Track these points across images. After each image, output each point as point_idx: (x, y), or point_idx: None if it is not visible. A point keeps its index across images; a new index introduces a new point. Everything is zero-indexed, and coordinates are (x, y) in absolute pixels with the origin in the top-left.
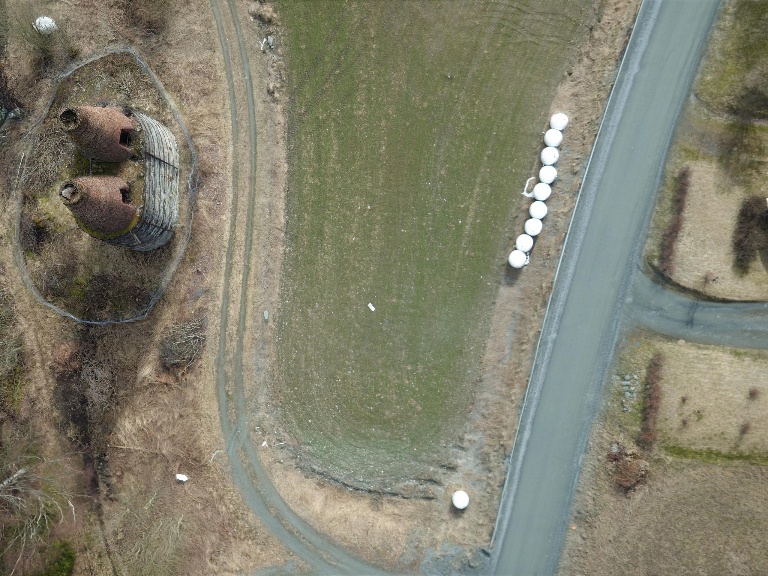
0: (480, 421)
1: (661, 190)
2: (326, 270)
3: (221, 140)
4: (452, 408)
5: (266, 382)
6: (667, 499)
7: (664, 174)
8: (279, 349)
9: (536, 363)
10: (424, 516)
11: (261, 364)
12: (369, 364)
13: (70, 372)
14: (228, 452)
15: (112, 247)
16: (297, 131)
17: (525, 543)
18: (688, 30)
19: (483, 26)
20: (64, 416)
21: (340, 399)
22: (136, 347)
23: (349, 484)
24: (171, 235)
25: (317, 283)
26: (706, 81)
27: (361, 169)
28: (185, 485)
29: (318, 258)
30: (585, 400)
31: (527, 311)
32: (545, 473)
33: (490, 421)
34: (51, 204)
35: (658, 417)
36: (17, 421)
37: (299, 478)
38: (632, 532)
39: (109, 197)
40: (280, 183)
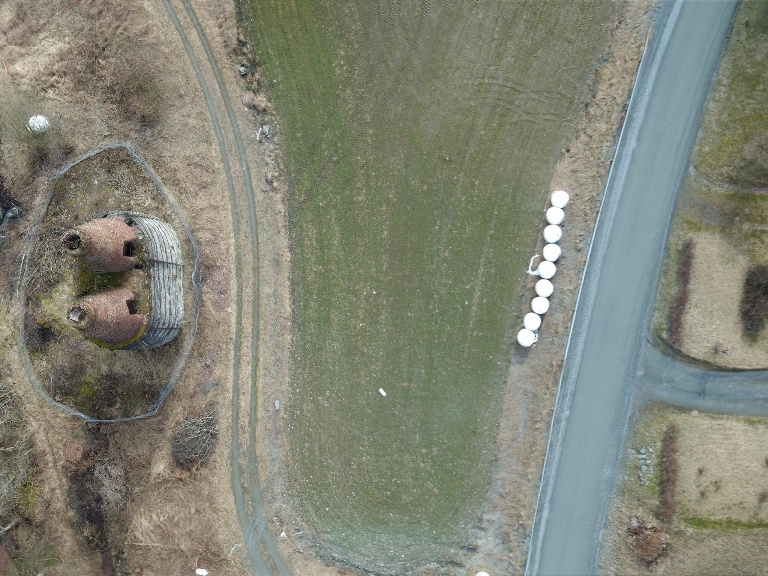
0: (498, 500)
1: (666, 263)
2: (335, 357)
3: (222, 232)
4: (469, 489)
5: (281, 472)
6: (689, 570)
7: (668, 247)
8: (292, 438)
9: (551, 442)
10: None
11: (275, 454)
12: (383, 449)
13: (83, 470)
14: (247, 545)
15: None
16: (298, 219)
17: None
18: (684, 103)
19: (478, 107)
20: (79, 515)
21: (356, 486)
22: (148, 443)
23: (370, 570)
24: (178, 331)
25: (327, 370)
26: (704, 152)
27: (364, 255)
28: None
29: (326, 345)
30: (602, 476)
31: (539, 389)
32: (566, 551)
33: (508, 500)
34: (55, 305)
35: (676, 490)
36: (33, 524)
37: (319, 567)
38: None
39: (116, 312)
40: (284, 272)
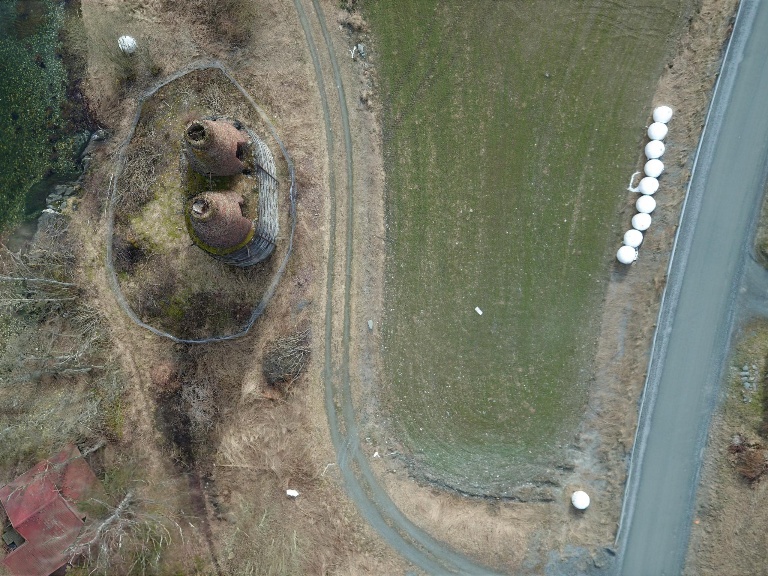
0: (595, 420)
1: None
2: (430, 276)
3: (316, 151)
4: (566, 408)
5: (374, 392)
6: None
7: None
8: (386, 358)
9: (653, 358)
10: (543, 519)
11: (368, 374)
12: (479, 368)
13: (170, 393)
14: (340, 465)
15: (210, 264)
16: (393, 138)
17: (650, 540)
18: None
19: (580, 23)
20: (167, 437)
21: (451, 405)
22: (237, 364)
23: (464, 490)
24: (272, 249)
25: (421, 290)
26: None
27: (461, 173)
28: (296, 500)
29: (421, 264)
30: (703, 393)
31: (639, 307)
32: (667, 468)
33: (606, 419)
34: (146, 224)
35: None
36: (120, 445)
37: (413, 487)
38: (758, 523)
39: (232, 210)
40: (378, 191)
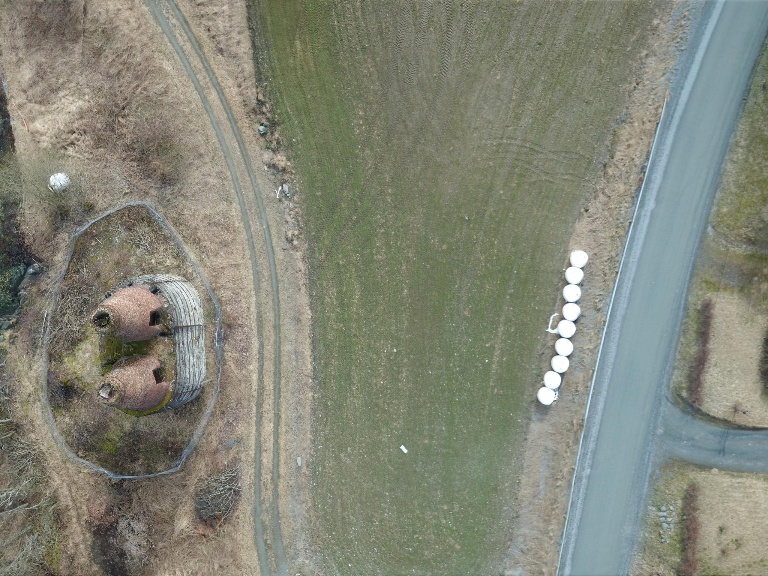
0: (519, 557)
1: (685, 322)
2: (356, 414)
3: (243, 291)
4: (490, 545)
5: (303, 528)
6: None
7: (687, 306)
8: (314, 495)
9: (572, 500)
10: None
11: (297, 510)
12: (405, 506)
13: (106, 526)
14: None
15: None
16: (318, 277)
17: None
18: (701, 164)
19: (497, 167)
20: (103, 570)
21: (378, 542)
22: (171, 498)
23: None
24: (200, 390)
25: (348, 428)
26: (722, 213)
27: (385, 313)
28: None
29: (347, 403)
30: (623, 533)
31: (559, 447)
32: None
33: (529, 556)
34: (78, 363)
35: (697, 547)
36: None
37: None
38: None
39: (144, 384)
40: (305, 330)
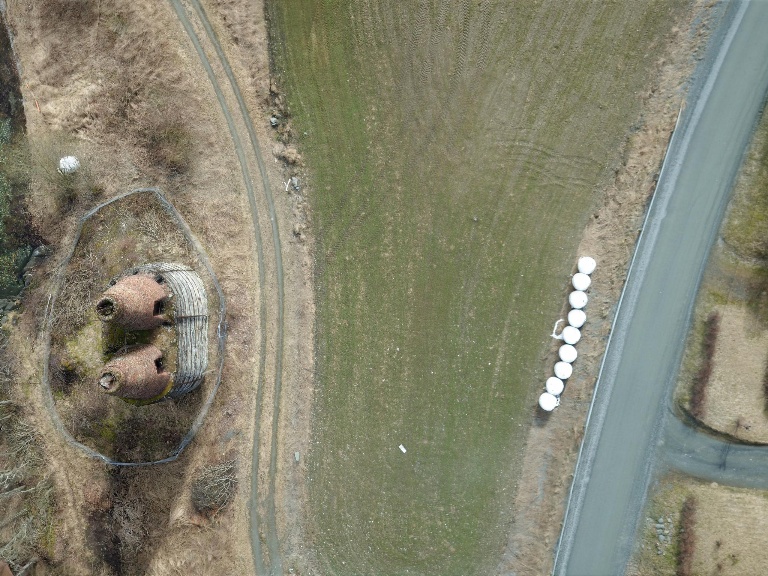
0: (514, 562)
1: (691, 333)
2: (356, 411)
3: (248, 282)
4: (486, 549)
5: (299, 523)
6: None
7: (693, 318)
8: (311, 490)
9: (570, 508)
10: None
11: (293, 505)
12: (401, 506)
13: (102, 511)
14: None
15: None
16: (324, 272)
17: None
18: (714, 175)
19: (508, 169)
20: (97, 556)
21: (373, 540)
22: (167, 487)
23: None
24: (201, 381)
25: (347, 424)
26: (733, 225)
27: (389, 311)
28: None
29: (348, 399)
30: (619, 543)
31: (559, 453)
32: None
33: (524, 562)
34: (80, 348)
35: (693, 561)
36: (51, 564)
37: None
38: None
39: (145, 374)
40: (308, 324)
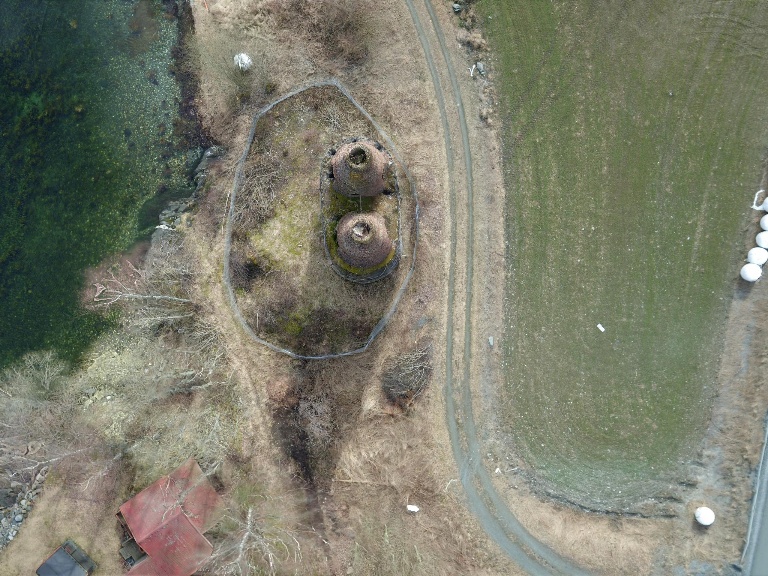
0: (718, 436)
1: None
2: (551, 293)
3: (436, 168)
4: (689, 425)
5: (494, 408)
6: None
7: None
8: (506, 374)
9: None
10: (667, 534)
11: (488, 390)
12: (601, 385)
13: (287, 408)
14: (462, 480)
15: (331, 281)
16: (513, 156)
17: None
18: None
19: (703, 42)
20: (284, 453)
21: (573, 421)
22: (356, 380)
23: (586, 506)
24: (395, 266)
25: (542, 307)
26: None
27: (583, 190)
28: (416, 516)
29: (542, 281)
30: None
31: (764, 324)
32: None
33: (729, 436)
34: (266, 241)
35: None
36: (239, 460)
37: (535, 503)
38: None
39: (383, 232)
40: (498, 208)
